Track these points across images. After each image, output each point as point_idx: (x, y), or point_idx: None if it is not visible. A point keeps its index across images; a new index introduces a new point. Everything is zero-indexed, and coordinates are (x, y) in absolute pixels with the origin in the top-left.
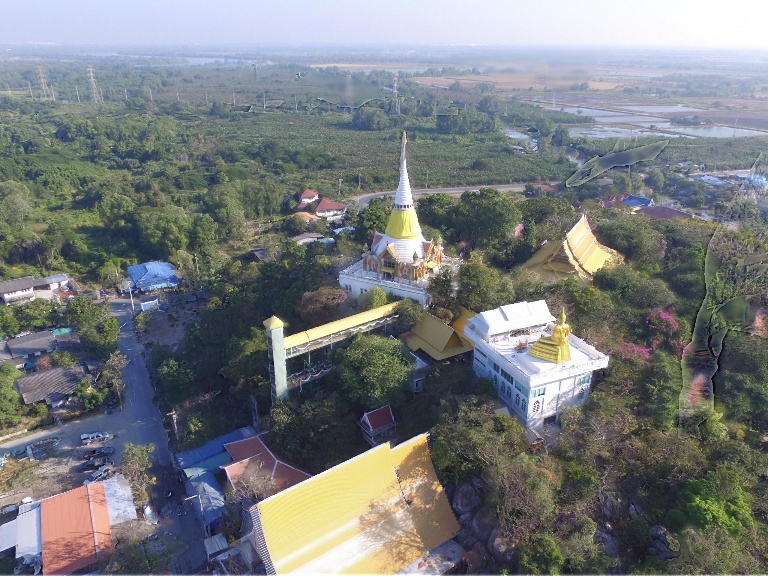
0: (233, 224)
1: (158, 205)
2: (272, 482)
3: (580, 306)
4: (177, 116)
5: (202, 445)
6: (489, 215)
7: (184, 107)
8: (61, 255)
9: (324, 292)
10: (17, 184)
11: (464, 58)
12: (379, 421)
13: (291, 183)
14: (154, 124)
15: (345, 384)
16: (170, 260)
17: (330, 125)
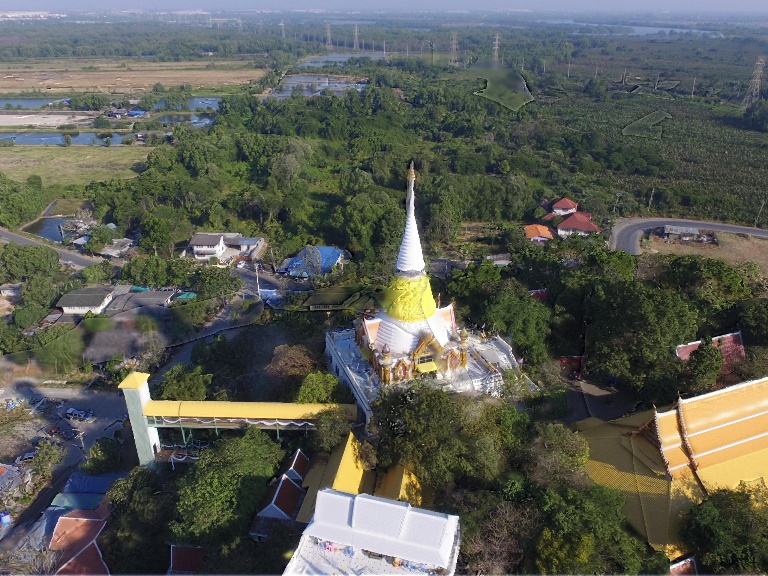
0: (437, 224)
1: None
2: (11, 572)
3: (535, 561)
4: (545, 91)
5: (98, 475)
6: (627, 311)
7: (560, 81)
8: (281, 219)
9: (288, 353)
10: (304, 144)
11: (764, 45)
12: (187, 562)
13: (570, 186)
14: None
15: (177, 491)
16: (350, 248)
17: (710, 118)
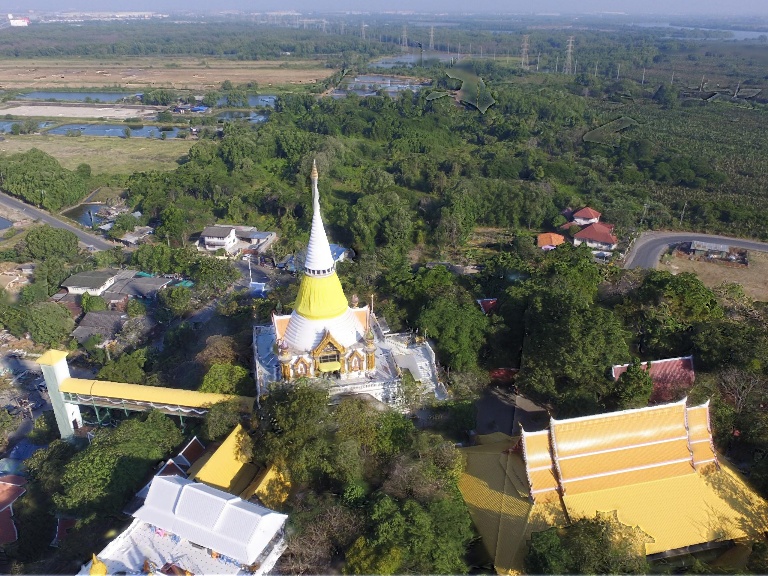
0: (444, 227)
1: (435, 188)
2: None
3: None
4: (610, 96)
5: (41, 445)
6: (555, 325)
7: (629, 87)
8: (298, 215)
9: (215, 343)
10: (336, 143)
11: (764, 49)
12: None
13: (602, 195)
14: (555, 102)
15: None
16: (354, 247)
17: None
